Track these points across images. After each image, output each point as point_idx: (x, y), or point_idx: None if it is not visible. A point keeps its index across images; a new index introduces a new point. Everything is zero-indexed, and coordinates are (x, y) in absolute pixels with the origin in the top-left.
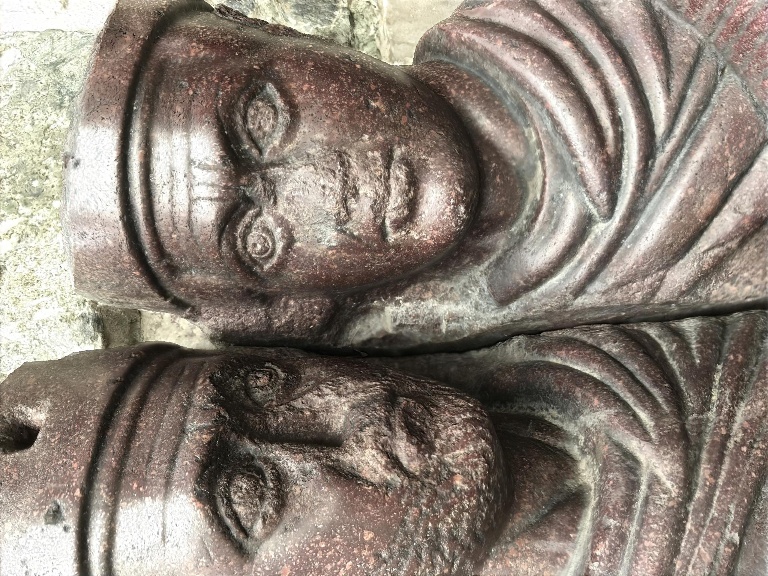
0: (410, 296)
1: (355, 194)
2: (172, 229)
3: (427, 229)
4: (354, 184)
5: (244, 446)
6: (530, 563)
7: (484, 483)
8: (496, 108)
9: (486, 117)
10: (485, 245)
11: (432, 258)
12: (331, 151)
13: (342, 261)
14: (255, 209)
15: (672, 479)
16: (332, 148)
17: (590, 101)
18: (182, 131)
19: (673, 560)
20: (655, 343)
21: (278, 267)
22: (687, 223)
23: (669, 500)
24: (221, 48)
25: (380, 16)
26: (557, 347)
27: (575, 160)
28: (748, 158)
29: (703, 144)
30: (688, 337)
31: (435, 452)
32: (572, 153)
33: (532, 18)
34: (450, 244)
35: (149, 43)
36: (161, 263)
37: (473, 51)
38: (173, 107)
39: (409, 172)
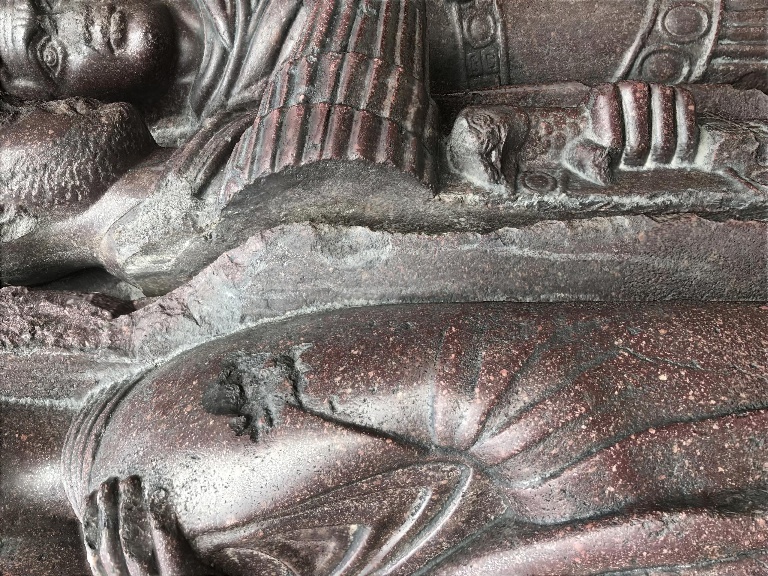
0: (160, 126)
1: (92, 24)
2: (5, 45)
3: (133, 48)
4: (92, 19)
5: (6, 107)
6: (146, 174)
7: (117, 123)
8: (188, 6)
9: (182, 10)
10: (187, 80)
11: (144, 71)
12: (83, 5)
13: (92, 67)
14: (47, 37)
15: (210, 123)
16: (84, 4)
17: None
18: None
19: (199, 150)
20: None
21: (62, 73)
22: (266, 45)
23: (205, 129)
24: None
25: None
26: None
27: (213, 18)
28: (291, 11)
29: (270, 6)
30: None
31: (96, 110)
32: (211, 15)
33: None
34: (149, 60)
35: None
36: (1, 69)
37: None
38: None
39: (122, 16)
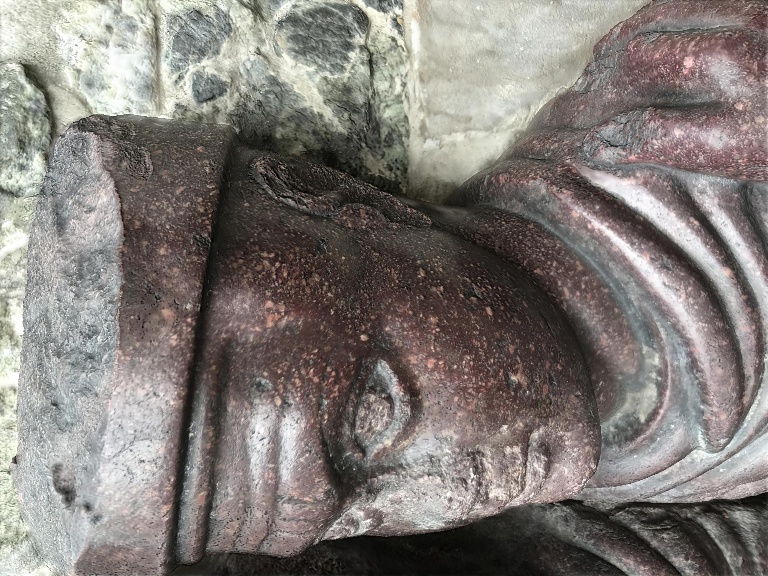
0: None
1: (485, 500)
2: (228, 549)
3: (543, 499)
4: (486, 490)
5: None
6: None
7: None
8: (616, 318)
9: (603, 330)
10: None
11: None
12: (463, 454)
13: None
14: (344, 509)
15: None
16: (464, 449)
17: (739, 345)
18: (267, 462)
19: None
20: (718, 551)
21: None
22: None
23: None
24: (311, 307)
25: (409, 64)
26: (622, 552)
27: (706, 407)
28: None
29: None
30: (747, 542)
31: None
32: (706, 400)
33: (687, 224)
34: None
35: (202, 315)
36: None
37: (600, 244)
38: (250, 424)
39: (547, 461)
